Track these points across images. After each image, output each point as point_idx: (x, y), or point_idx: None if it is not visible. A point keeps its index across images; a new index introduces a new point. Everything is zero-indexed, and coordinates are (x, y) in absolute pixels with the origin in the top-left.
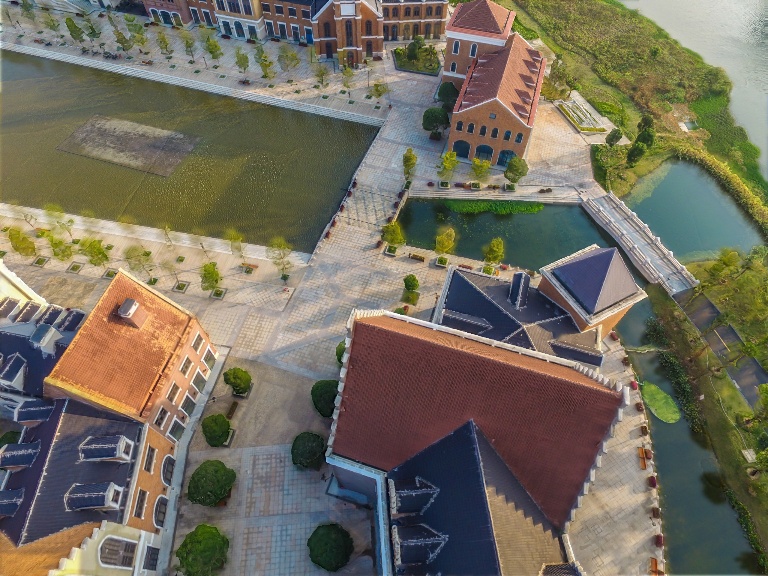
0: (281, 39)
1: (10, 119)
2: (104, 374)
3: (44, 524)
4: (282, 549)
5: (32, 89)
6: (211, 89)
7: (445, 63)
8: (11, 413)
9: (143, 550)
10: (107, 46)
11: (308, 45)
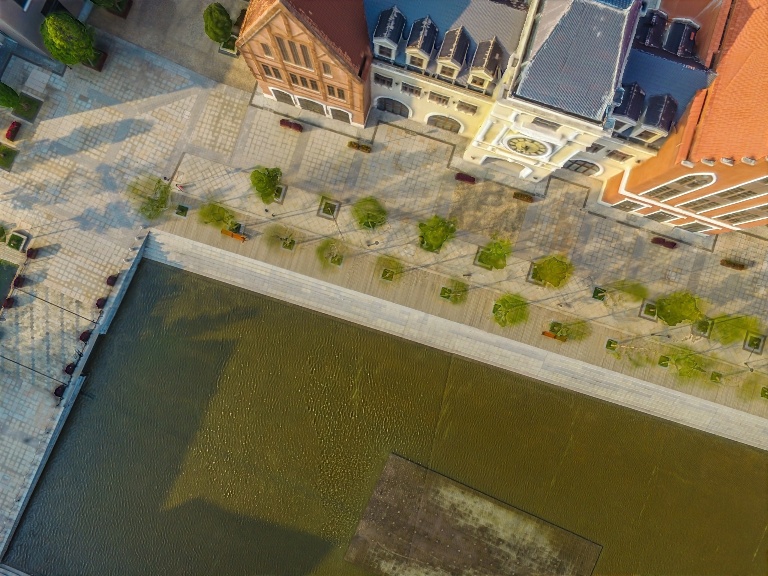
0: None
1: None
2: None
3: None
4: None
5: None
6: None
7: None
8: None
9: None
10: None
11: None
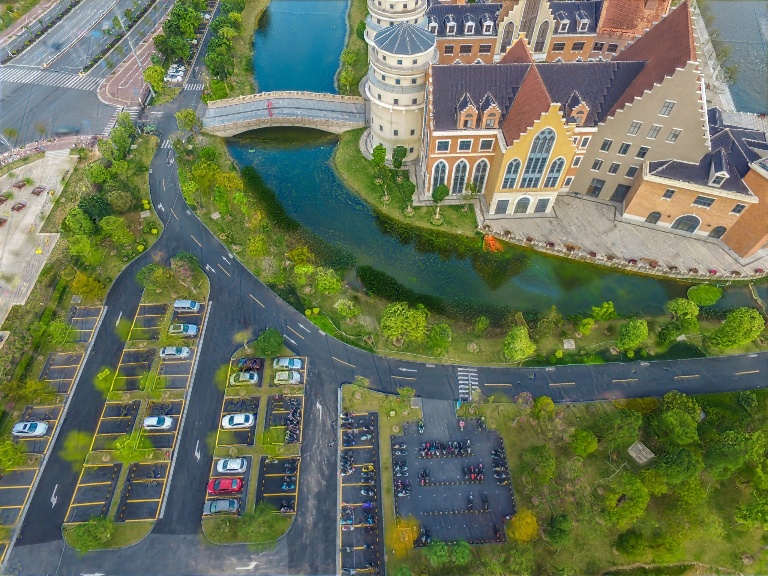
0: None
1: None
2: (617, 3)
3: (551, 7)
4: None
5: None
6: None
7: None
8: None
9: (538, 59)
10: None
11: None
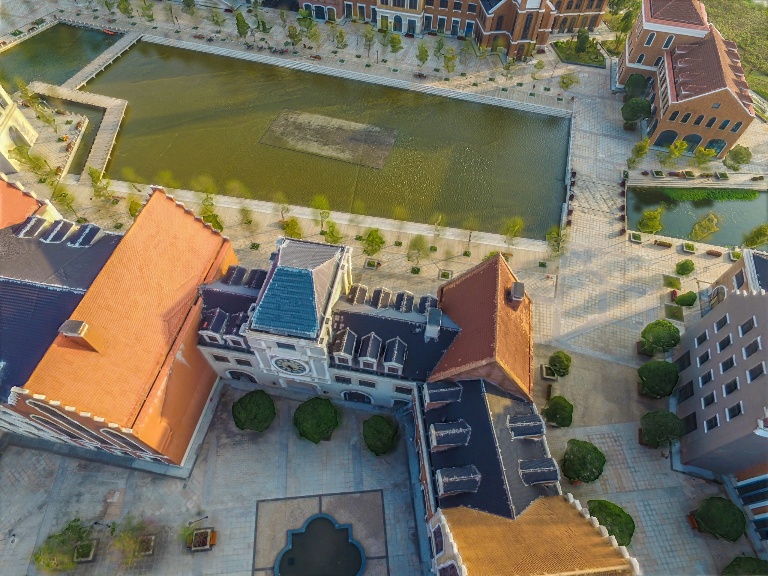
0: (437, 33)
1: (201, 114)
2: (512, 355)
3: (520, 497)
4: (653, 523)
5: (210, 84)
6: (388, 83)
7: (633, 55)
8: (336, 399)
9: None
10: (268, 41)
11: (467, 39)
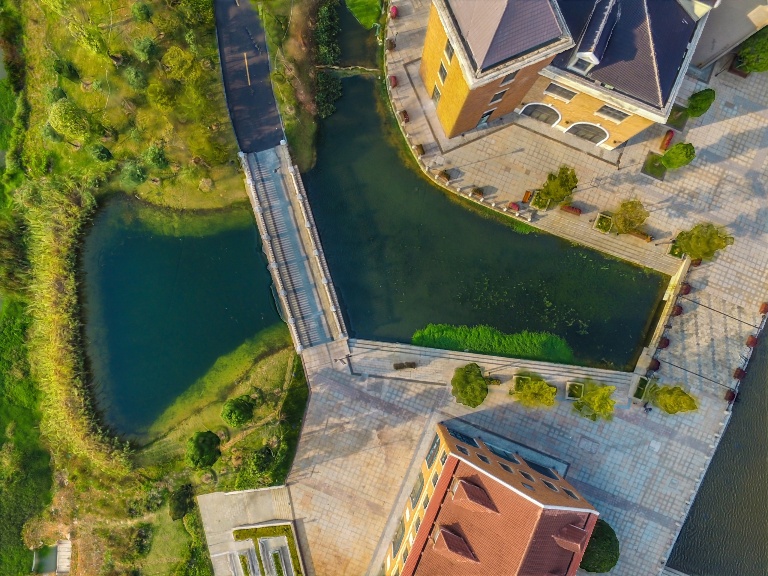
0: None
1: None
2: None
3: None
4: None
5: None
6: None
7: None
8: None
9: None
10: None
11: None
